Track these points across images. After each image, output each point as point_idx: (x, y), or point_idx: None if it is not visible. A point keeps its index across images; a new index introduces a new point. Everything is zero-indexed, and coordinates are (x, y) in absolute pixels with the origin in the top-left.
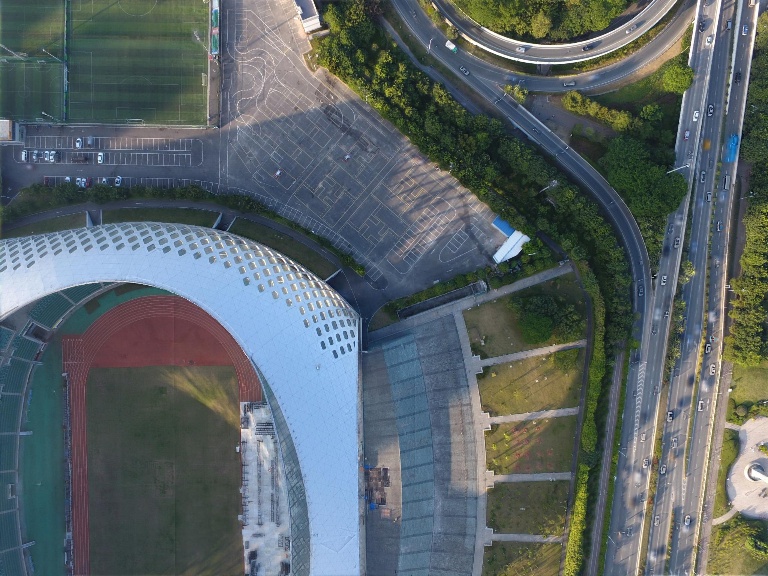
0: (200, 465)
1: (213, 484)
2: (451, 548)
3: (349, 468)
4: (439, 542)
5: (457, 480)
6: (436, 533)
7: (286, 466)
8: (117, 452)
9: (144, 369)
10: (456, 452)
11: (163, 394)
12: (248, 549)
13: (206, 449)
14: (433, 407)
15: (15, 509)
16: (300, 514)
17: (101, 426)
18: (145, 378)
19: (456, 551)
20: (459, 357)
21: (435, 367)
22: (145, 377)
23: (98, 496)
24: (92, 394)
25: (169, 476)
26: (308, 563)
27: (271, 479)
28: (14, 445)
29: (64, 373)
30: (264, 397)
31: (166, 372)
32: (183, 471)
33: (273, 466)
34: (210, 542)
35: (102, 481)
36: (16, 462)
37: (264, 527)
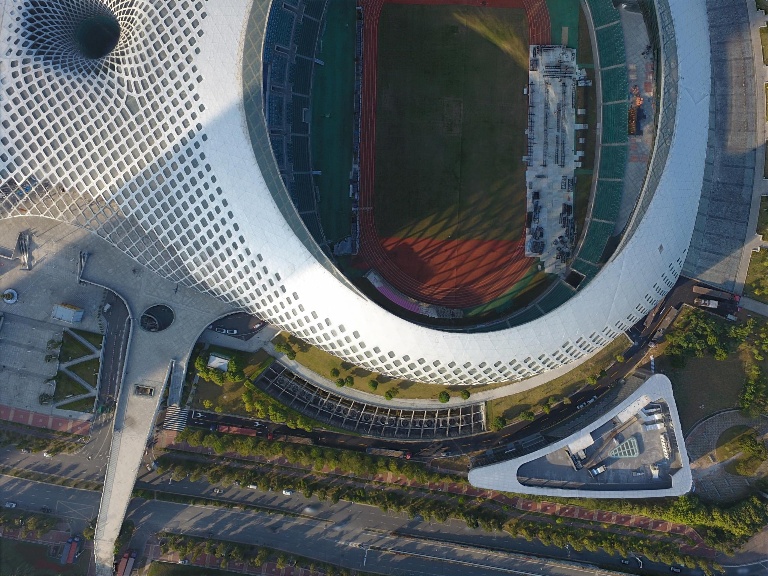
0: (488, 105)
1: (500, 124)
2: (728, 197)
3: (704, 30)
4: (717, 191)
5: (737, 131)
6: (714, 182)
7: (660, 6)
8: (406, 88)
9: (437, 7)
10: (737, 104)
11: (455, 33)
12: (531, 189)
13: (494, 89)
14: (717, 59)
15: (307, 135)
16: (671, 53)
17: (392, 61)
18: (437, 16)
19: (733, 201)
20: (744, 11)
21: (720, 20)
22: (437, 15)
23: (386, 131)
24: (384, 29)
25: (457, 114)
26: (675, 103)
27: (557, 122)
28: (309, 71)
29: (358, 6)
30: (553, 41)
31: (459, 11)
32: (471, 110)
33: (560, 108)
34: (494, 181)
35: (390, 116)
36: (310, 88)
37: (548, 169)
